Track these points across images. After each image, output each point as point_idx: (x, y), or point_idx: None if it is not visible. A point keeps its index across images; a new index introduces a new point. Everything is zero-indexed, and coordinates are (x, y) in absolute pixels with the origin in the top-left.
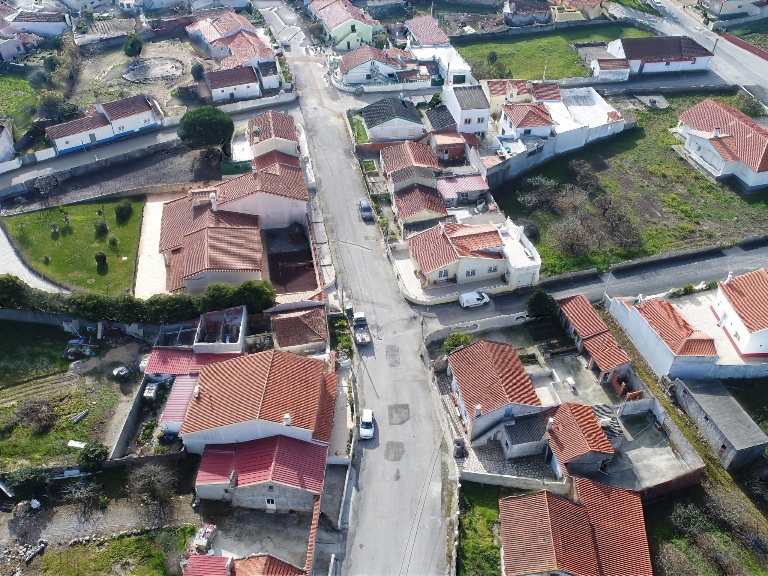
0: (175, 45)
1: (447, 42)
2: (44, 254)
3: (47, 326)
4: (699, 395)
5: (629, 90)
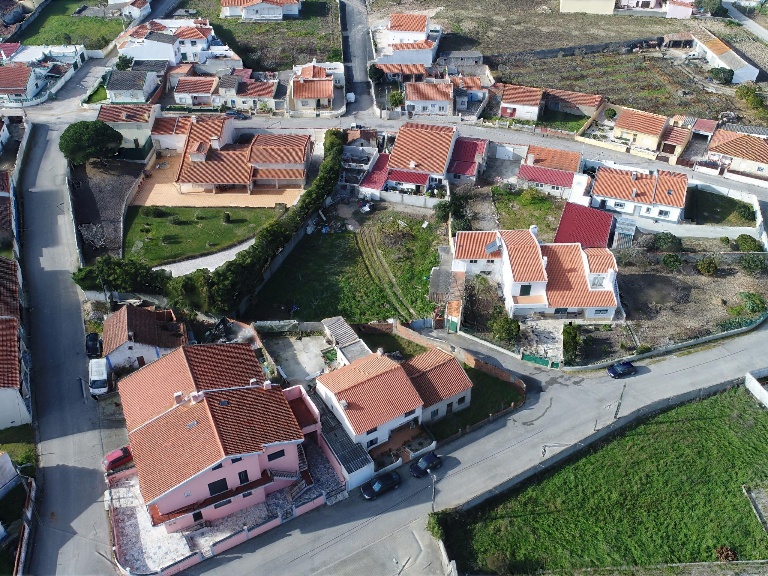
0: None
1: (20, 46)
2: (201, 247)
3: (301, 242)
4: (451, 56)
5: (165, 14)
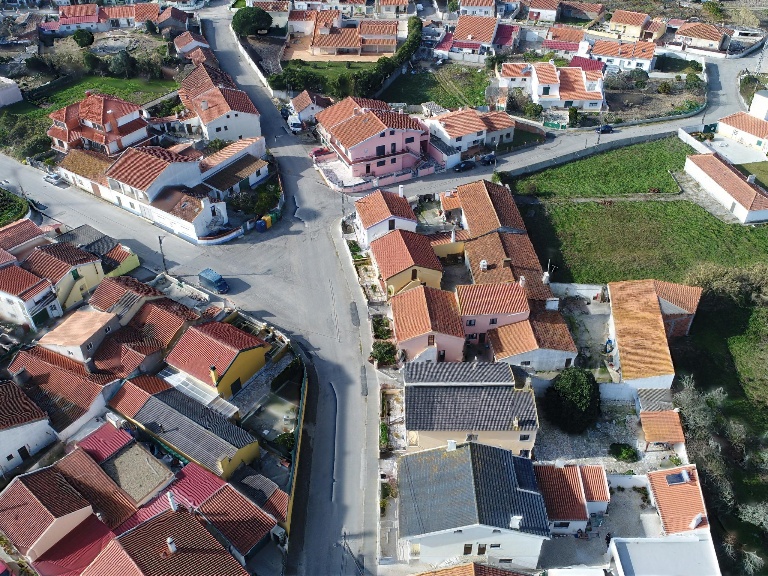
0: (70, 39)
1: None
2: None
3: None
4: None
5: None
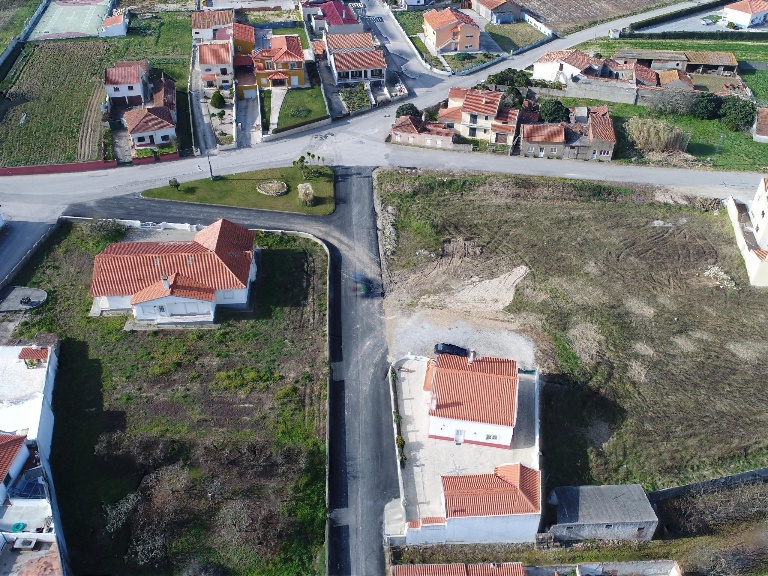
0: None
1: None
2: None
3: None
4: (581, 517)
5: None
